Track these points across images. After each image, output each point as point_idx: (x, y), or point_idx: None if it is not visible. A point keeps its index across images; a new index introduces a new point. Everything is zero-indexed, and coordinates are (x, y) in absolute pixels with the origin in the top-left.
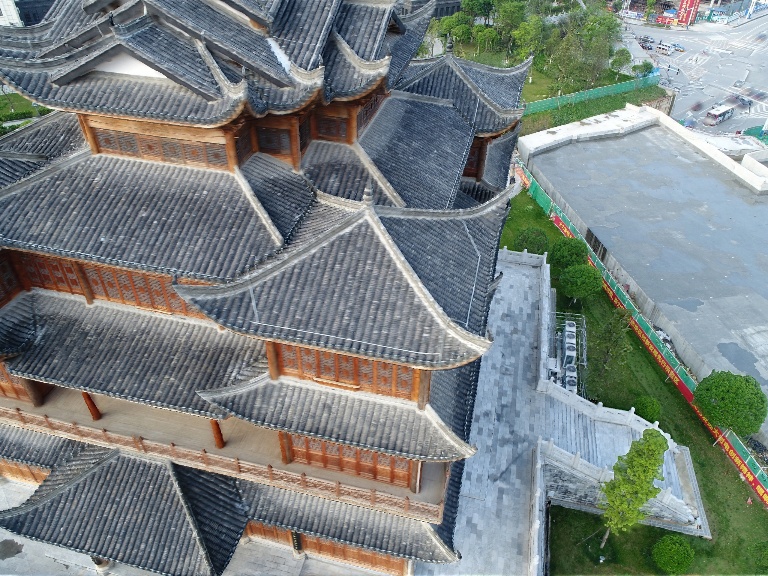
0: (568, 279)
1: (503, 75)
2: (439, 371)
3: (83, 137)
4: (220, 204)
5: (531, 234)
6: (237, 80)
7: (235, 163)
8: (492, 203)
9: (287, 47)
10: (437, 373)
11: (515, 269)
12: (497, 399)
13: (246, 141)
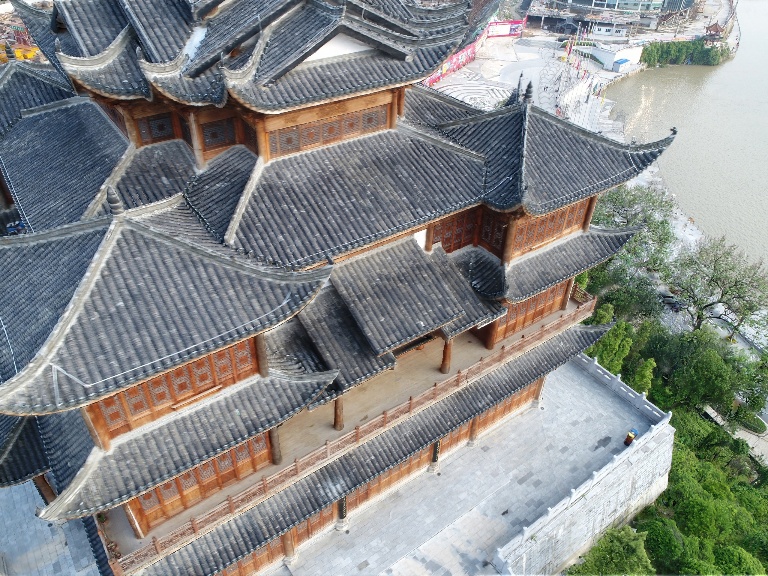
0: None
1: None
2: None
3: (402, 121)
4: None
5: None
6: None
7: None
8: None
9: None
10: None
11: None
12: None
13: None
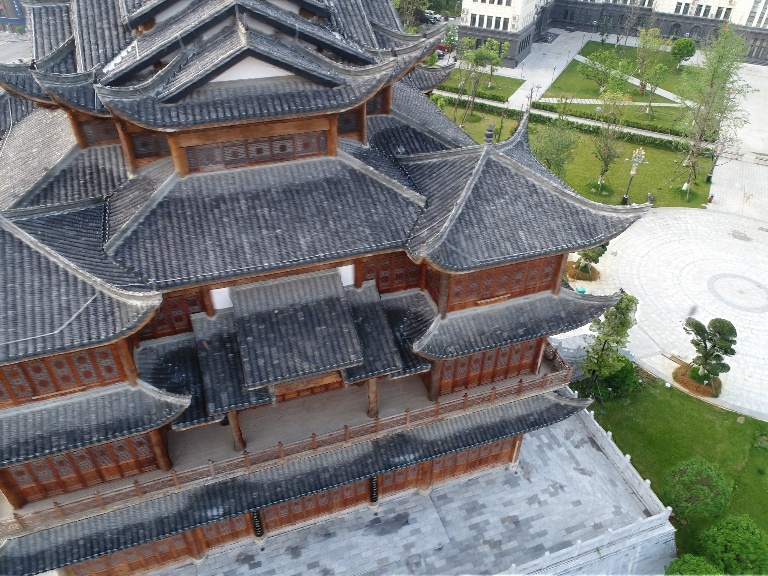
0: (674, 568)
1: (584, 208)
2: (28, 416)
3: None
4: (47, 166)
5: (694, 474)
6: (76, 67)
7: (76, 140)
8: (137, 297)
9: (130, 52)
10: (23, 415)
11: (617, 492)
12: (361, 574)
13: (110, 128)
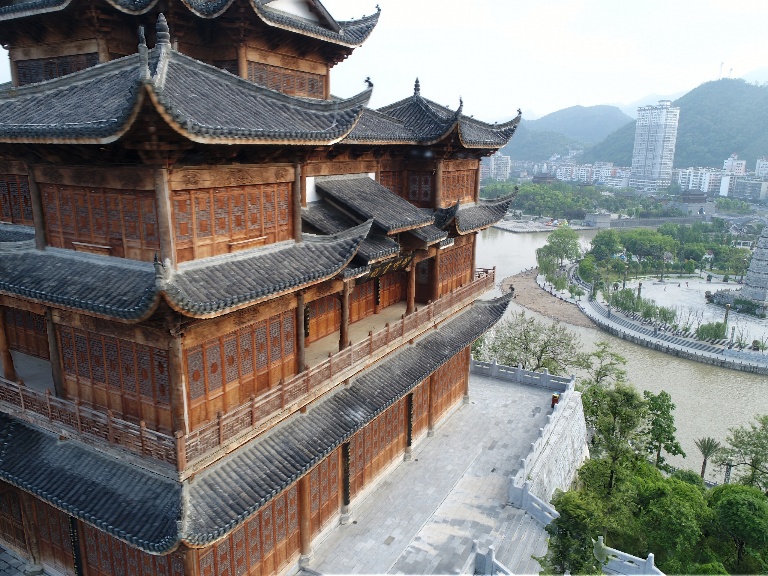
0: None
1: None
2: None
3: None
4: None
5: None
6: None
7: None
8: None
9: None
10: None
11: None
12: None
13: None
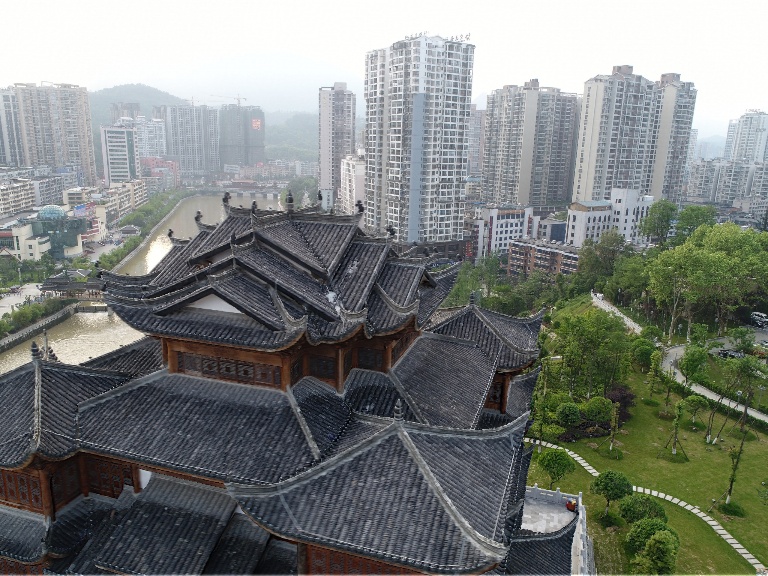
0: None
1: (457, 525)
2: None
3: None
4: None
5: None
6: None
7: None
8: None
9: None
10: None
11: None
12: None
13: None
